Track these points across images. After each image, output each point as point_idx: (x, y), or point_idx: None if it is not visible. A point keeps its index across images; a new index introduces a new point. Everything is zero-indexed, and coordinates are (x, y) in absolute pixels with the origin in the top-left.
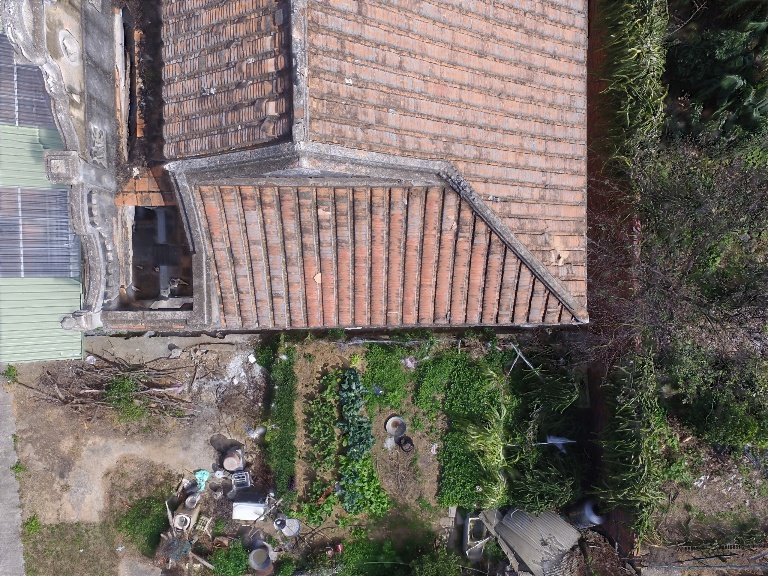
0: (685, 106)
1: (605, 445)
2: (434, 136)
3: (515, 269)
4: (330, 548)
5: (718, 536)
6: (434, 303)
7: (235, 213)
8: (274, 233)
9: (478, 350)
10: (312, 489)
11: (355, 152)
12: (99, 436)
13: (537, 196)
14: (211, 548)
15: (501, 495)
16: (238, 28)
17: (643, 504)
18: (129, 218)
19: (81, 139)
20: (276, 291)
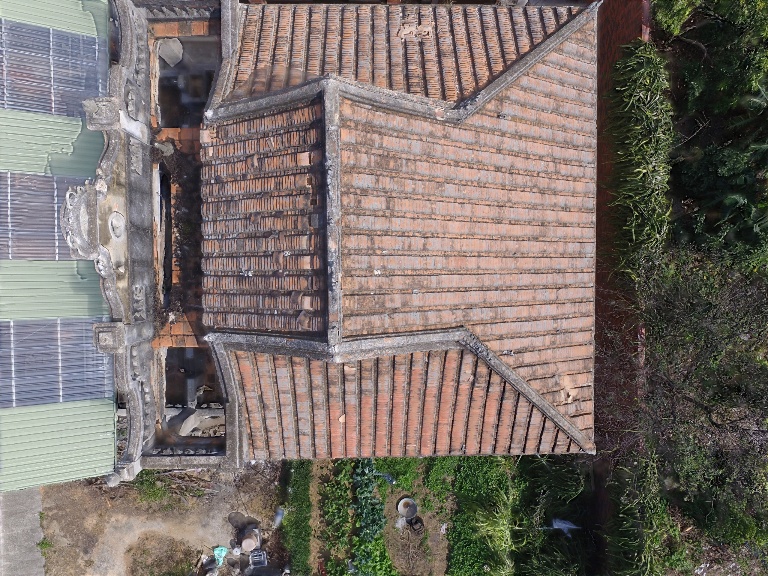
0: (688, 209)
1: (609, 539)
2: (454, 305)
3: (527, 411)
4: None
5: None
6: (450, 437)
7: (267, 370)
8: (303, 384)
9: None
10: (327, 569)
11: (383, 341)
12: (122, 513)
13: (548, 343)
14: None
15: None
16: (275, 222)
17: None
18: (163, 352)
19: (125, 306)
20: (302, 430)
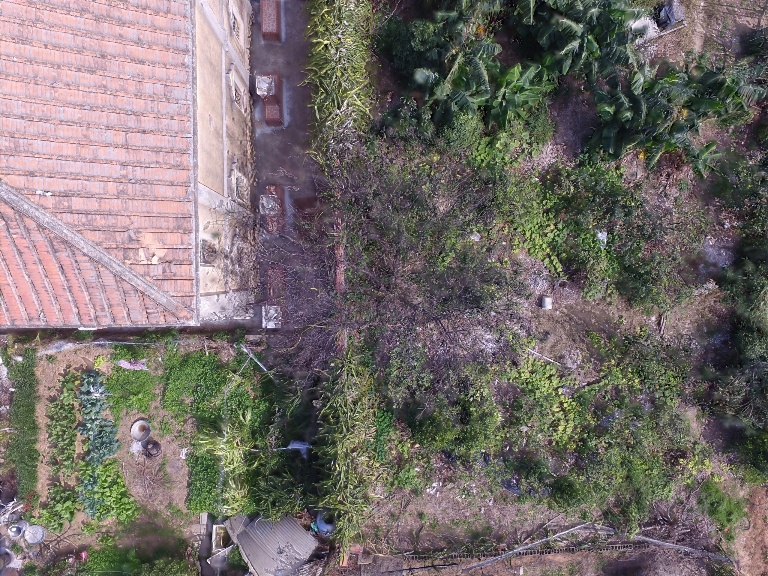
0: None
1: (315, 451)
2: None
3: (92, 268)
4: (72, 556)
5: (448, 545)
6: (23, 303)
7: None
8: None
9: (227, 352)
10: None
11: None
12: None
13: (114, 191)
14: None
15: (242, 502)
16: None
17: (341, 512)
18: None
19: None
20: None
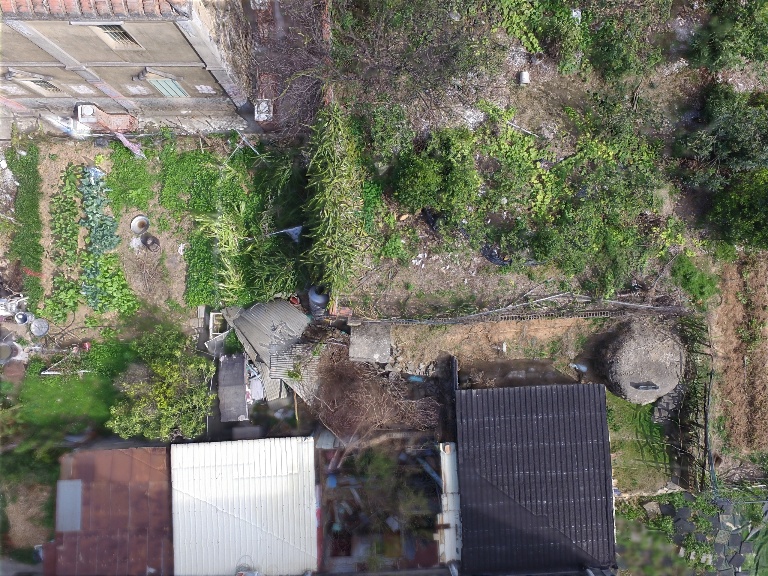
0: None
1: (305, 210)
2: None
3: None
4: (76, 345)
5: (434, 311)
6: None
7: None
8: None
9: (221, 150)
10: (54, 284)
11: None
12: None
13: None
14: None
15: (238, 287)
16: None
17: (330, 257)
18: None
19: None
20: None
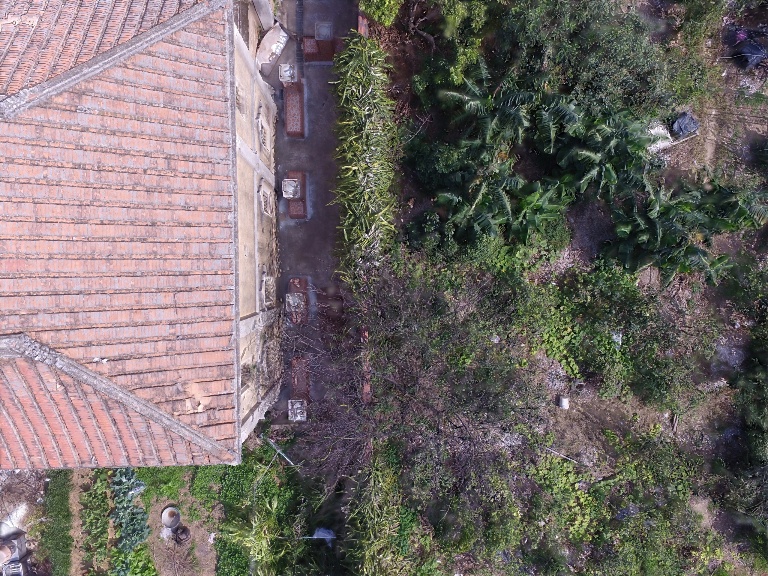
0: None
1: (342, 550)
2: (9, 311)
3: (143, 421)
4: None
5: None
6: (76, 449)
7: None
8: None
9: (253, 441)
10: None
11: None
12: None
13: (164, 349)
14: None
15: None
16: None
17: None
18: None
19: None
20: None
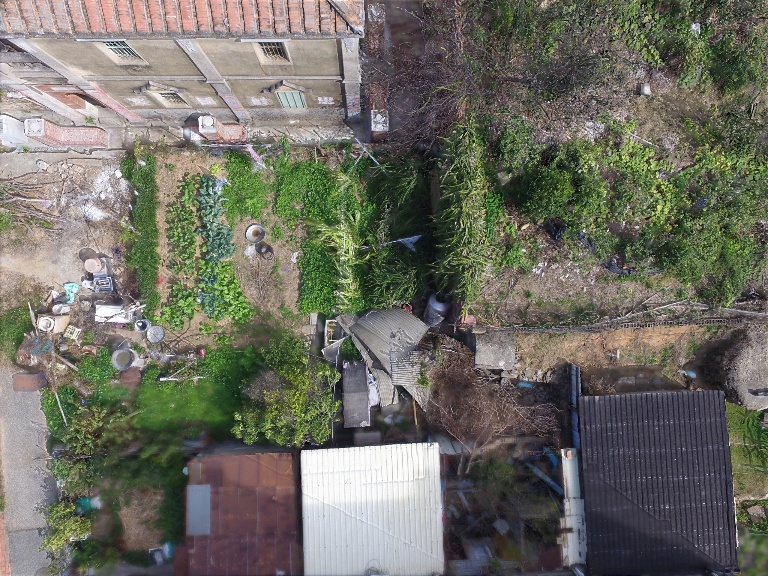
0: None
1: (435, 220)
2: None
3: None
4: (192, 352)
5: (555, 319)
6: (210, 7)
7: None
8: None
9: (335, 159)
10: (172, 292)
11: None
12: None
13: None
14: (80, 357)
15: (354, 294)
16: None
17: (465, 267)
18: None
19: None
20: None
